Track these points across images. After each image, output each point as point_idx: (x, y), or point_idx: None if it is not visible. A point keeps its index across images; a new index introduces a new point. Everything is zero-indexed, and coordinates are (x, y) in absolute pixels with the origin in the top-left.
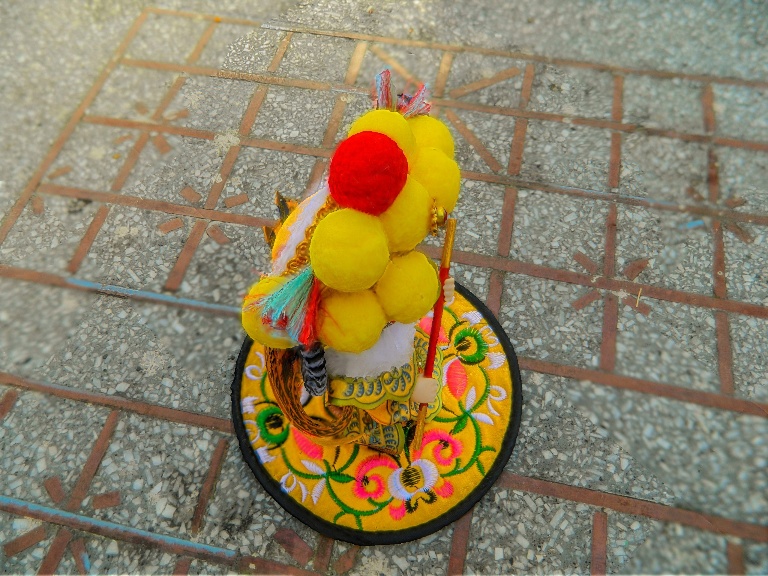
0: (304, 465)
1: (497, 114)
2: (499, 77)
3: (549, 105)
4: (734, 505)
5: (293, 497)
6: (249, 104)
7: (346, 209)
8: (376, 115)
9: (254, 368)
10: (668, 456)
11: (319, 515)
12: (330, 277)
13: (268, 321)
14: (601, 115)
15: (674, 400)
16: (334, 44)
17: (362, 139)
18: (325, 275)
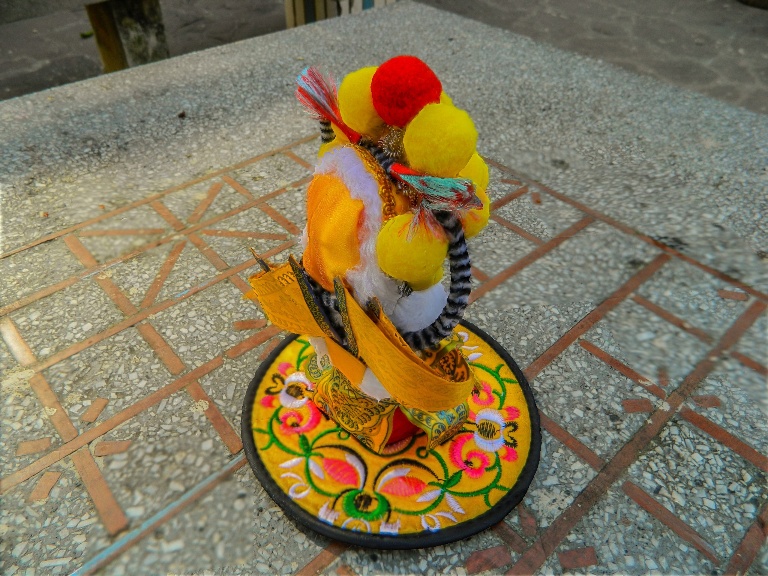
0: (422, 502)
1: (240, 212)
2: (212, 194)
3: (267, 188)
4: (611, 283)
5: (447, 526)
6: (3, 340)
7: (426, 106)
8: (357, 72)
9: (295, 487)
10: (563, 289)
11: (477, 515)
12: (461, 147)
13: (459, 199)
14: (305, 174)
15: (529, 265)
16: (38, 252)
17: (394, 60)
18: (457, 149)
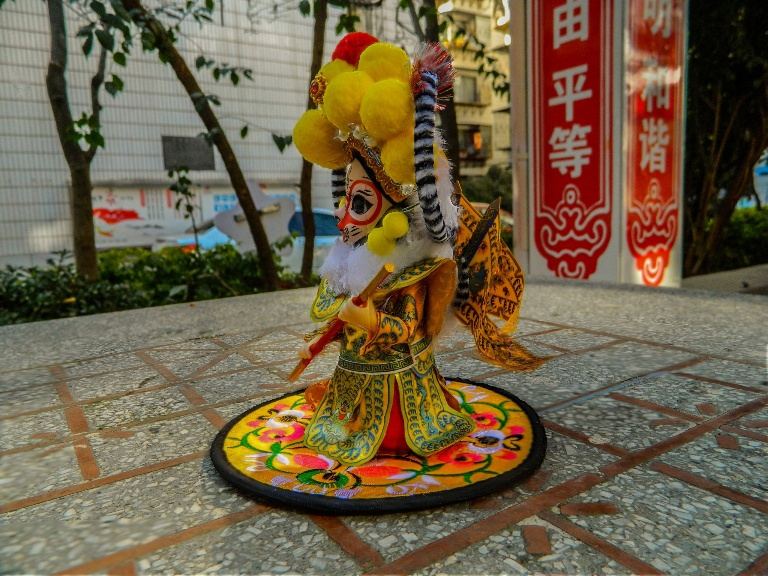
0: None
1: None
2: None
3: None
4: None
5: None
6: None
7: None
8: None
9: (471, 389)
10: (3, 542)
11: None
12: None
13: None
14: None
15: None
16: None
17: None
18: None
